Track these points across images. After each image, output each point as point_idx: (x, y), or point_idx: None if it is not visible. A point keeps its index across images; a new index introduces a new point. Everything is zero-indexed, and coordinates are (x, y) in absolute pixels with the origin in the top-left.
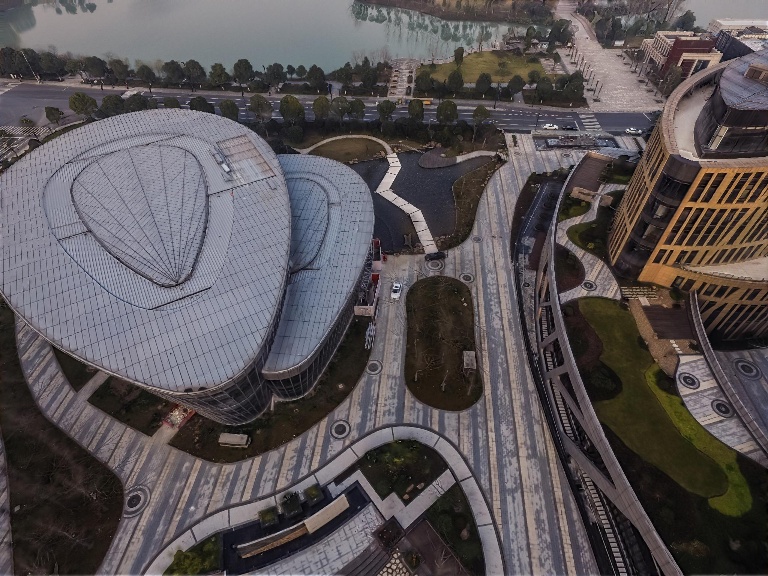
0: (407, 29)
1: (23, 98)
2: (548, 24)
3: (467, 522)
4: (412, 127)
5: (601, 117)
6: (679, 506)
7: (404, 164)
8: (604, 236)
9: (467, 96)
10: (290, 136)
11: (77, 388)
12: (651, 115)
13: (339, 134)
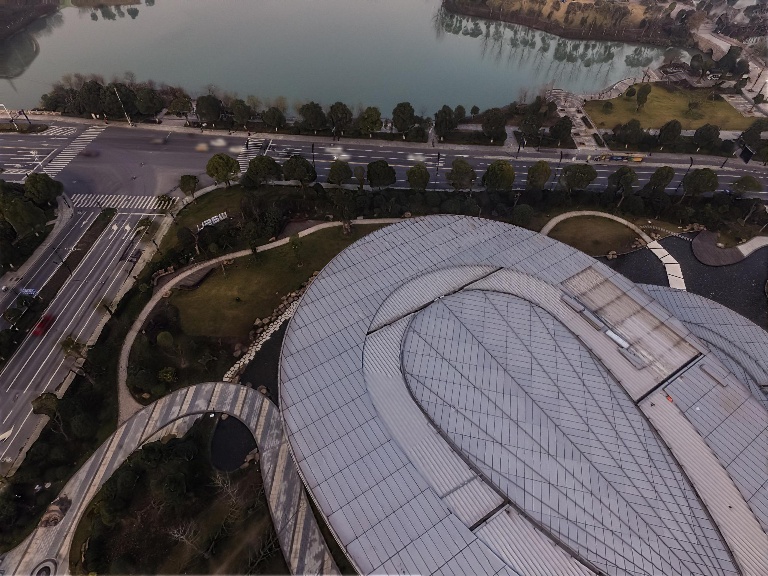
0: (510, 46)
1: (120, 149)
2: (690, 46)
3: None
4: (667, 204)
5: None
6: None
7: (677, 259)
8: None
9: (679, 150)
10: (517, 218)
11: None
12: None
13: (564, 210)
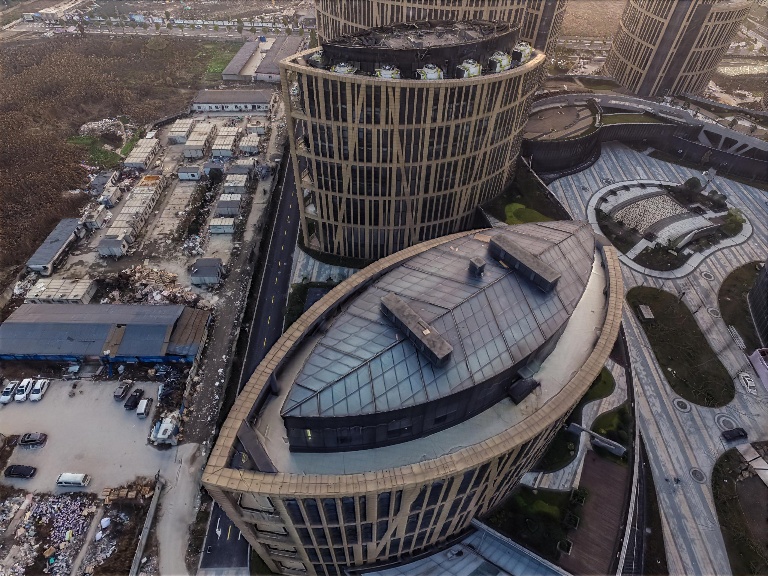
0: None
1: None
2: None
3: None
4: None
5: None
6: (540, 205)
7: None
8: None
9: None
10: None
11: None
12: None
13: None
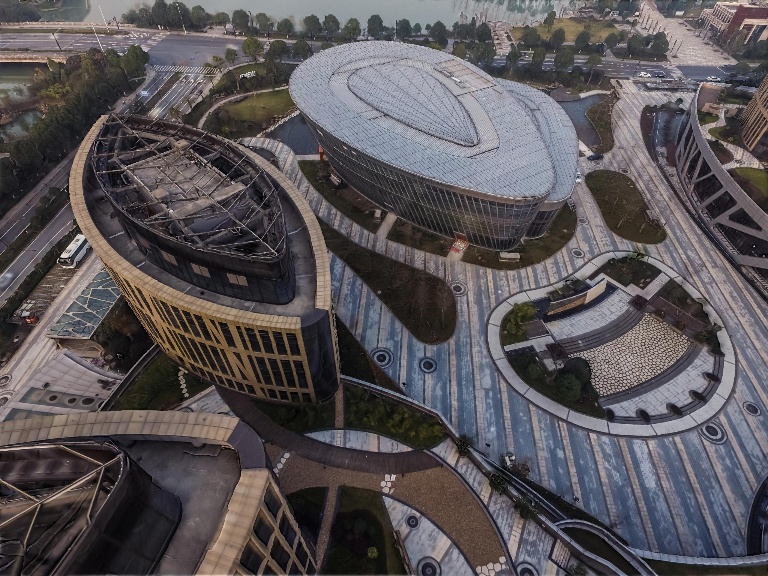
0: (474, 1)
1: (181, 45)
2: None
3: (688, 296)
4: (539, 70)
5: (683, 69)
6: None
7: None
8: (739, 133)
9: None
10: None
11: (374, 232)
12: (723, 68)
13: None
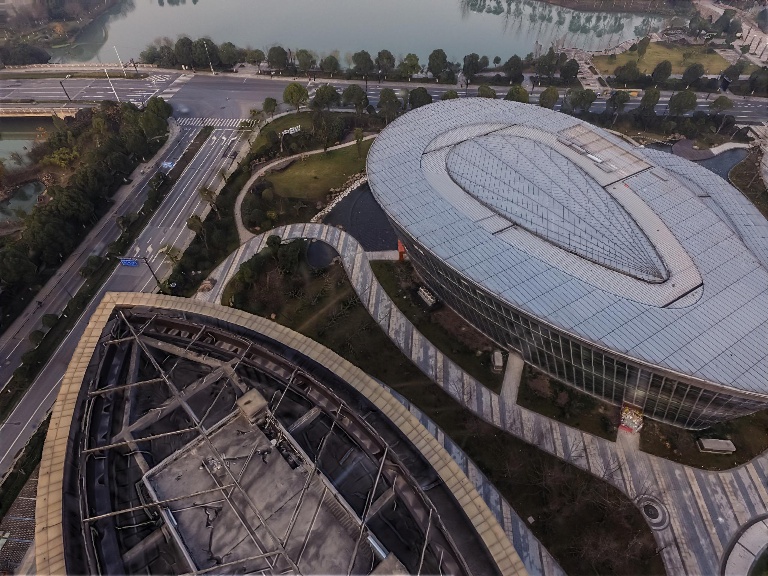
0: (529, 21)
1: (209, 90)
2: (693, 15)
3: None
4: (653, 118)
5: None
6: None
7: None
8: None
9: (671, 87)
10: None
11: (496, 390)
12: None
13: None
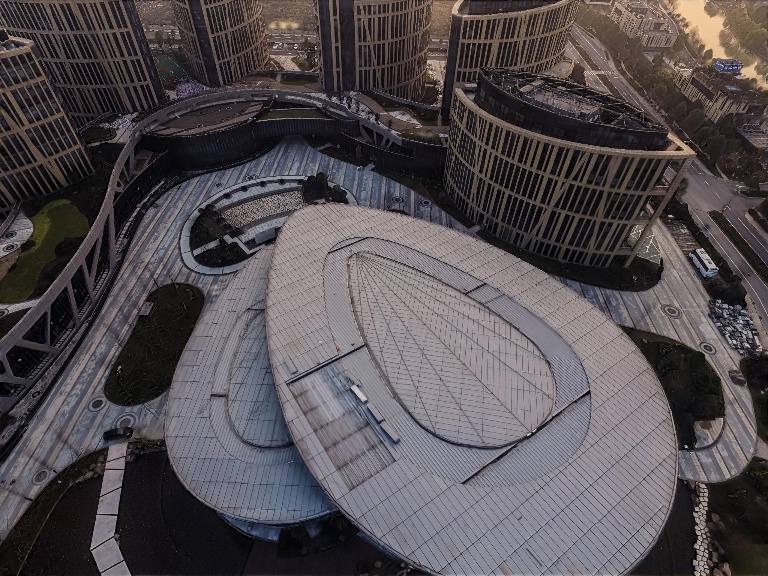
0: None
1: None
2: None
3: None
4: None
5: None
6: None
7: None
8: None
9: None
10: None
11: None
12: None
13: None
